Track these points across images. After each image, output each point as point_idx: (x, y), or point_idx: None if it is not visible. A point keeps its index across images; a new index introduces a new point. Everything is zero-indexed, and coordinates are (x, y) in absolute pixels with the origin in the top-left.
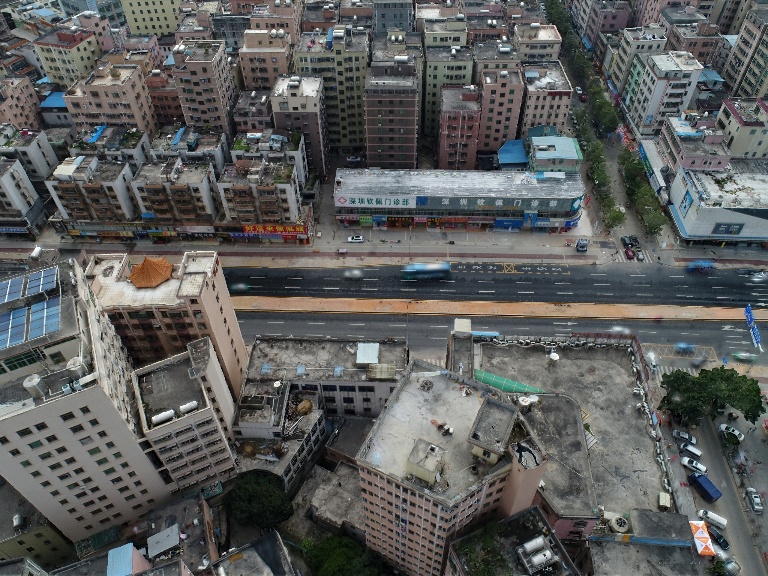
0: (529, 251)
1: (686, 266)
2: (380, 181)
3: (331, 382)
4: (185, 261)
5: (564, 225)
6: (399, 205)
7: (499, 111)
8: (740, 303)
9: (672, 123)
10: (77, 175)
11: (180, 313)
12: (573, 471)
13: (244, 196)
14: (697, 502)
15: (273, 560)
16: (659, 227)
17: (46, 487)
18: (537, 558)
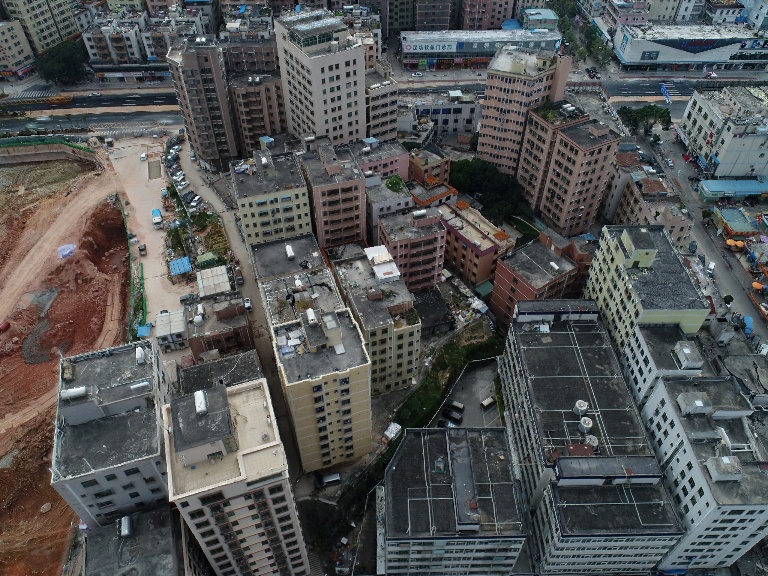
0: None
1: (626, 80)
2: (431, 36)
3: (438, 106)
4: None
5: None
6: (445, 50)
7: None
8: (659, 94)
9: (612, 0)
10: (242, 27)
11: None
12: None
13: None
14: None
15: (437, 152)
16: (608, 60)
17: (325, 115)
18: (569, 108)
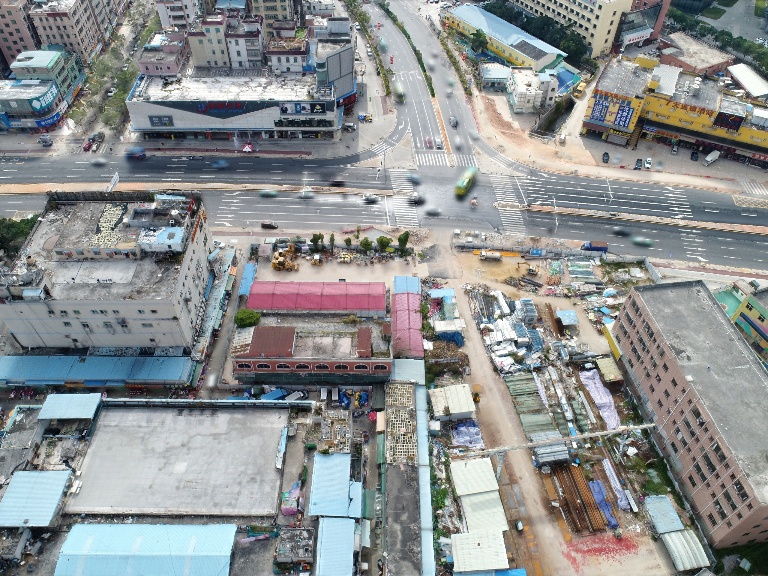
0: (1, 148)
1: (130, 154)
2: None
3: None
4: None
5: (36, 125)
6: None
7: (9, 32)
8: (150, 179)
9: (153, 39)
10: None
11: None
12: None
13: None
14: None
15: None
16: None
17: None
18: None
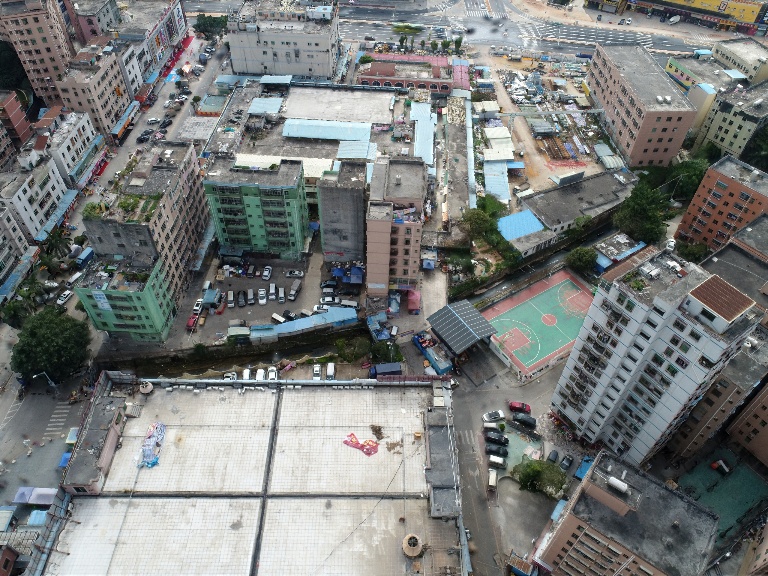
0: None
1: None
2: None
3: None
4: None
5: None
6: None
7: None
8: None
9: None
10: None
11: None
12: None
13: None
14: None
15: None
16: None
17: None
18: None
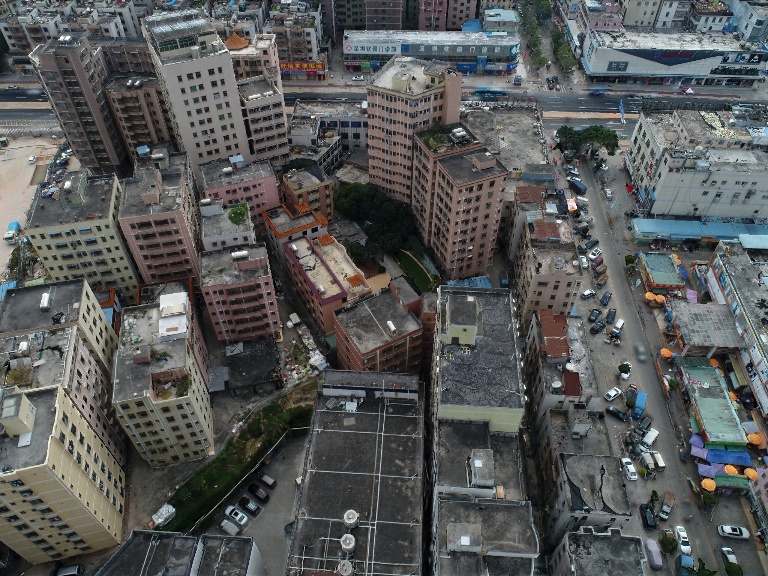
0: (481, 85)
1: (589, 93)
2: (376, 36)
3: (346, 118)
4: (256, 39)
5: (506, 68)
6: (389, 52)
7: None
8: None
9: (586, 2)
10: None
11: (256, 62)
12: (488, 138)
13: (281, 37)
14: (573, 195)
15: (317, 174)
16: (572, 70)
17: (192, 127)
18: (458, 133)
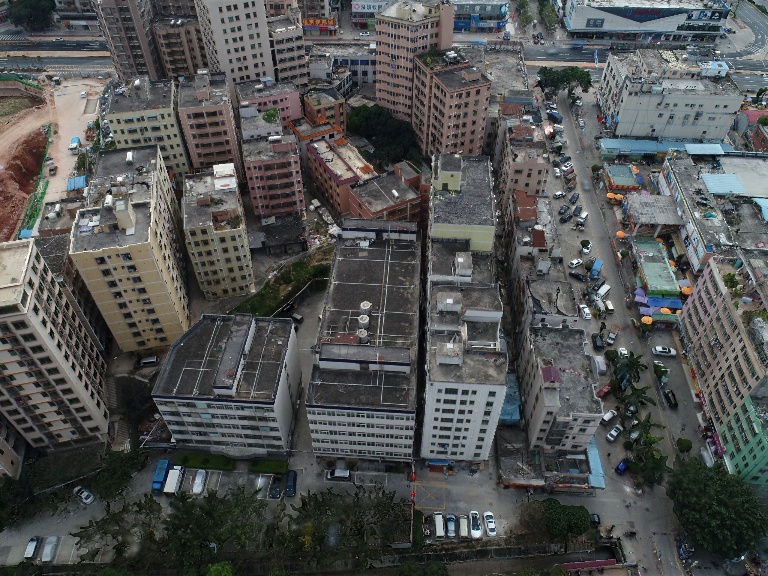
0: (474, 40)
1: (570, 47)
2: None
3: (356, 57)
4: None
5: (496, 25)
6: None
7: None
8: (598, 61)
9: None
10: None
11: (280, 6)
12: None
13: None
14: (551, 124)
15: (333, 95)
16: (555, 27)
17: (228, 54)
18: (451, 55)
